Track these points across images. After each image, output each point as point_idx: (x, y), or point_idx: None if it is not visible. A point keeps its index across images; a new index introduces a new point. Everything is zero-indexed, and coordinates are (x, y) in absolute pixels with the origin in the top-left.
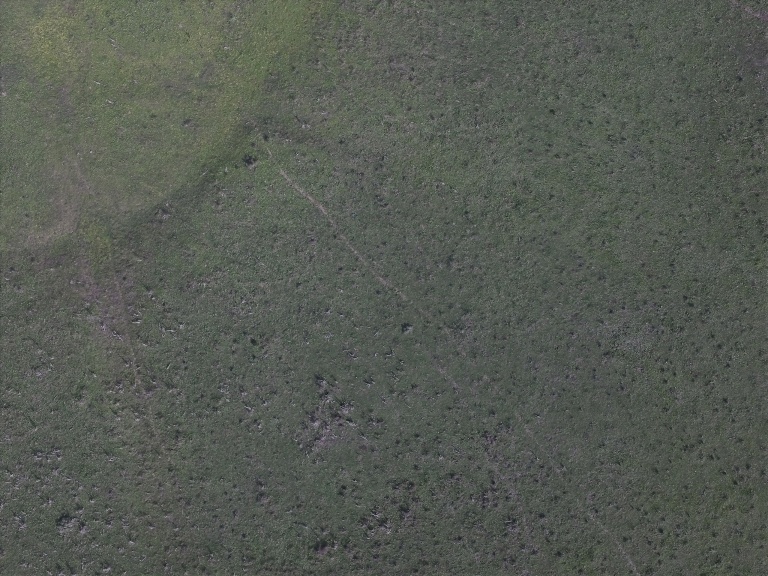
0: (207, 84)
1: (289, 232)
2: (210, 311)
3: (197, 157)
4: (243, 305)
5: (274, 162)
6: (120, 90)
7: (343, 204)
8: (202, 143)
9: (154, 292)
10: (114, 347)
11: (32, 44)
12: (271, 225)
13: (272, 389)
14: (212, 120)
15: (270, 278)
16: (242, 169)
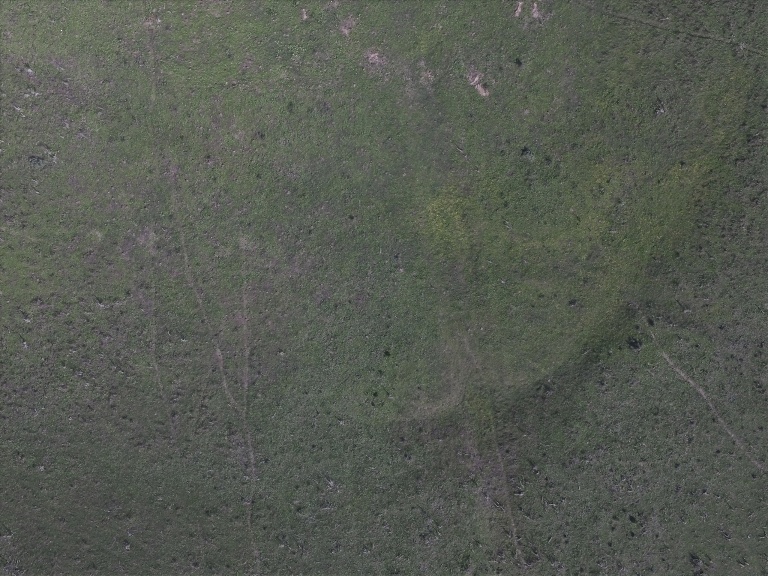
0: (592, 266)
1: (670, 414)
2: (591, 487)
3: (580, 336)
4: (623, 483)
5: (657, 345)
6: (510, 269)
7: (722, 389)
8: (585, 322)
9: (538, 467)
10: (495, 517)
11: (428, 222)
12: (652, 406)
13: (648, 565)
14: (595, 301)
15: (650, 458)
16: (626, 351)
